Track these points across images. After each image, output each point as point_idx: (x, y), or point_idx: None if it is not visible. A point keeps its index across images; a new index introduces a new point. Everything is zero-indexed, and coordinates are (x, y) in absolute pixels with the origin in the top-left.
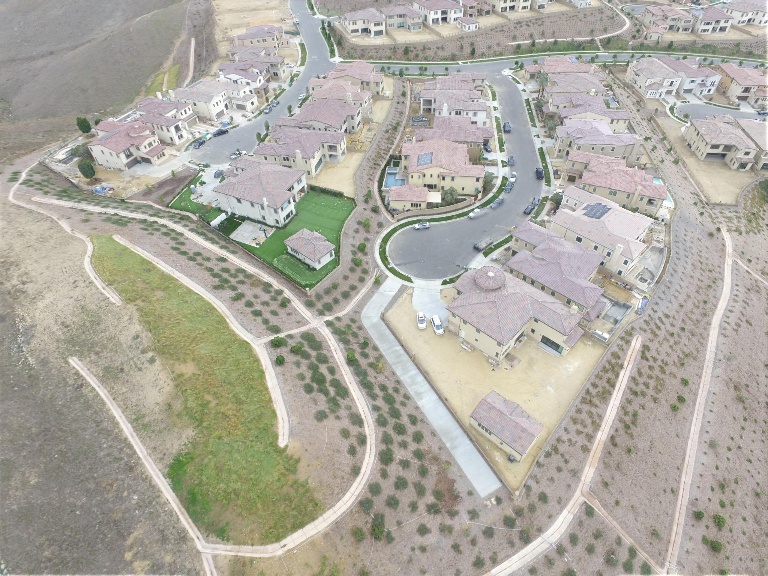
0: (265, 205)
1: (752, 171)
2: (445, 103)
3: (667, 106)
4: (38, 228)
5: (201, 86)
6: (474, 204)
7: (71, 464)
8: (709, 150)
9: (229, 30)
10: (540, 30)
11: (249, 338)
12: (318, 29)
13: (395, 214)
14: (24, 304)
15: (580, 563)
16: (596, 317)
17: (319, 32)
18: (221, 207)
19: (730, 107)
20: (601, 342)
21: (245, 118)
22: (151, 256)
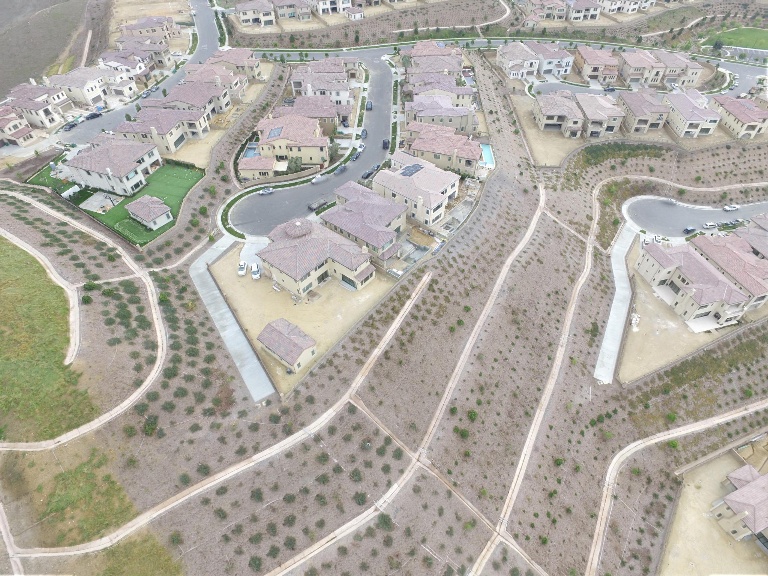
0: (110, 175)
1: (582, 138)
2: (309, 84)
3: (527, 85)
4: None
5: (76, 72)
6: (320, 172)
7: None
8: (546, 121)
9: (124, 22)
10: (424, 19)
11: (65, 284)
12: (213, 20)
13: (244, 182)
14: None
15: (335, 448)
16: (397, 259)
17: (214, 23)
18: (76, 181)
19: (582, 85)
20: (394, 278)
21: (122, 102)
22: None
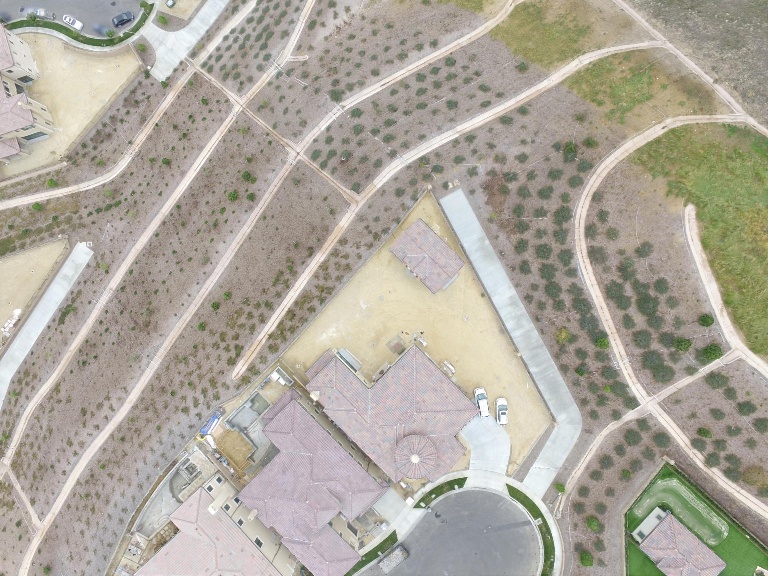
0: None
1: None
2: None
3: None
4: None
5: None
6: None
7: None
8: None
9: None
10: None
11: (752, 361)
12: None
13: None
14: None
15: (377, 148)
16: None
17: None
18: None
19: None
20: (284, 367)
21: None
22: None
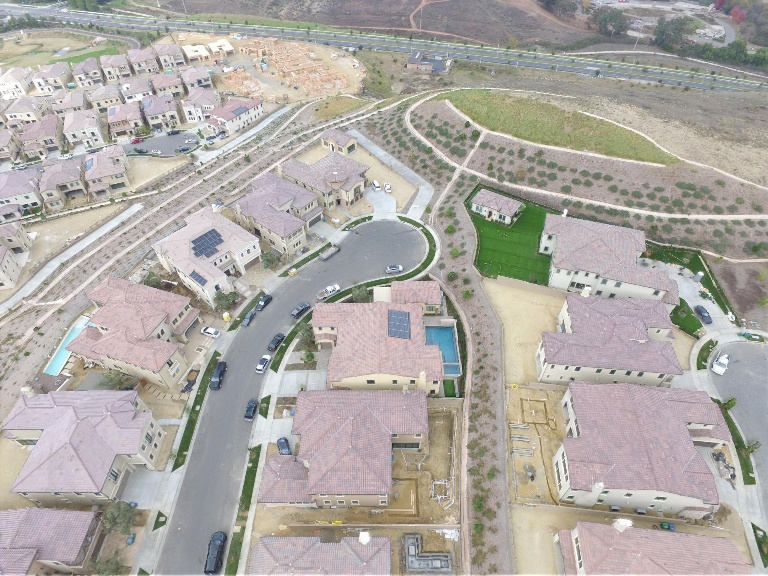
0: None
1: None
2: None
3: None
4: (748, 169)
5: None
6: None
7: (533, 85)
8: None
9: None
10: None
11: None
12: None
13: None
14: (643, 111)
15: None
16: None
17: None
18: None
19: None
20: None
21: None
22: (613, 159)
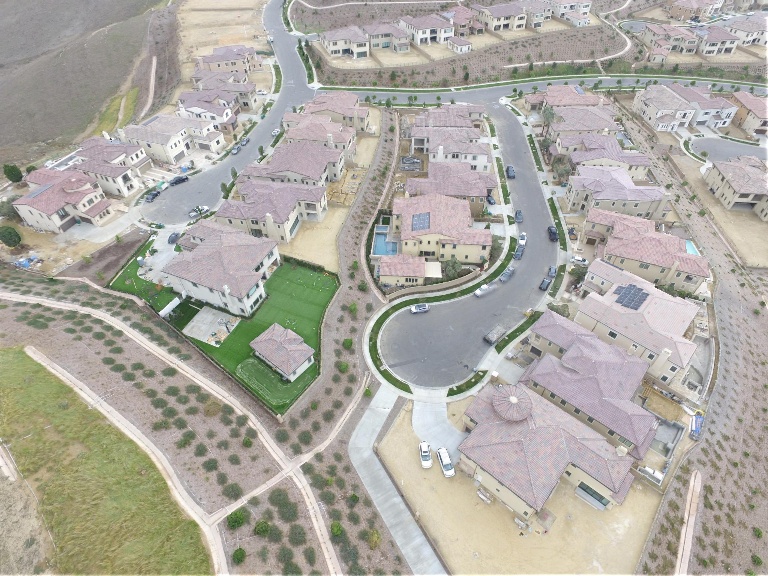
0: (226, 293)
1: None
2: (440, 145)
3: (681, 141)
4: None
5: (156, 124)
6: (480, 276)
7: None
8: (737, 199)
9: (195, 49)
10: (537, 51)
11: (198, 513)
12: (295, 48)
13: (387, 292)
14: None
15: None
16: None
17: (296, 52)
18: (174, 288)
19: (748, 142)
20: (653, 485)
21: (209, 161)
22: (73, 379)
